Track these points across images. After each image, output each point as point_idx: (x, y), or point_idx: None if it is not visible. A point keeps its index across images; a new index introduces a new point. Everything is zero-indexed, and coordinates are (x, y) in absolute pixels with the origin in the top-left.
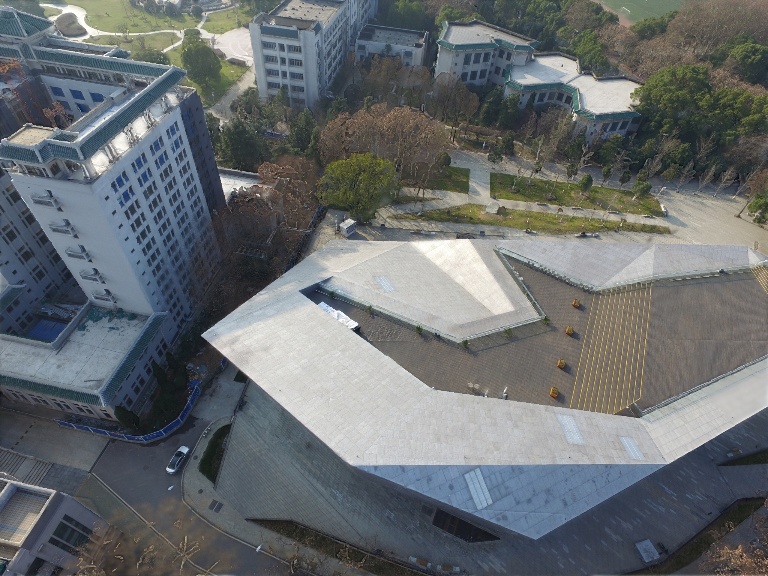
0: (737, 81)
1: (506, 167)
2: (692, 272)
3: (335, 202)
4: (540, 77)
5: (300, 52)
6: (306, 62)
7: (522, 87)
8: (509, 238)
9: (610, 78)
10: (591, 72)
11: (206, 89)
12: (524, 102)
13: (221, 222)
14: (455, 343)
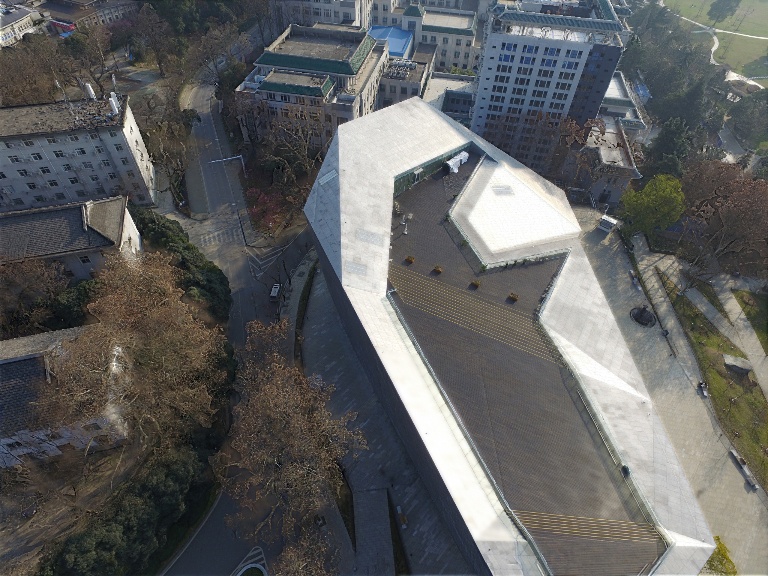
0: None
1: None
2: None
3: None
4: None
5: None
6: None
7: None
8: (675, 362)
9: None
10: None
11: None
12: None
13: (567, 153)
14: None
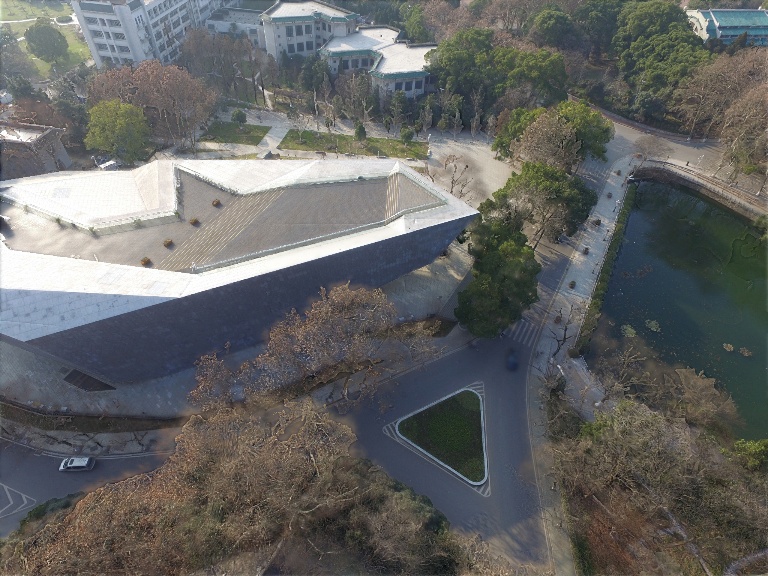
0: (515, 41)
1: (308, 125)
2: (333, 179)
3: (95, 146)
4: (355, 46)
5: (120, 26)
6: (129, 35)
7: (330, 54)
8: None
9: (421, 45)
10: (405, 41)
11: (55, 66)
12: (337, 68)
13: None
14: (86, 230)
